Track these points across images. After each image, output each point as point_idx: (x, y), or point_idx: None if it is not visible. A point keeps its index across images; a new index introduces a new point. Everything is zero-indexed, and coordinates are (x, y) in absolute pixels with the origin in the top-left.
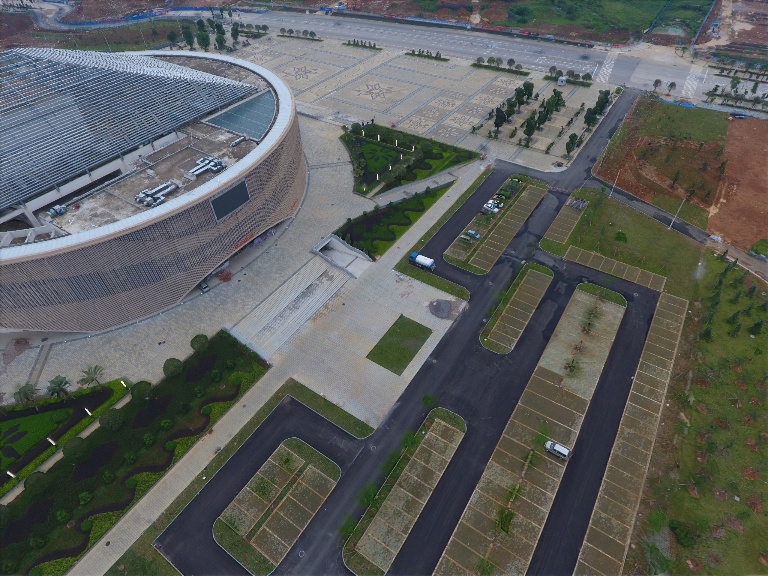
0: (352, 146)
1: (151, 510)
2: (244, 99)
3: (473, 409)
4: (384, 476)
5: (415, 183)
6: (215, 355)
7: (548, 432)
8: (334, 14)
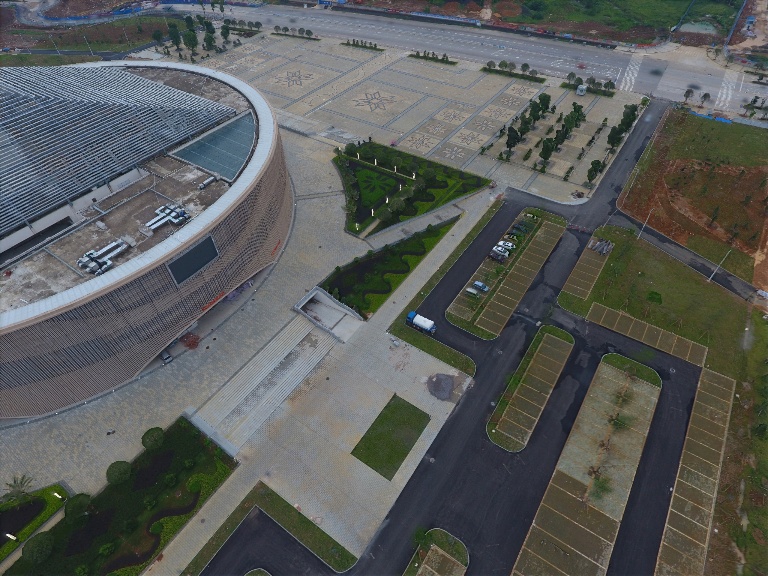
0: (345, 174)
1: None
2: (220, 124)
3: (477, 531)
4: None
5: (415, 219)
6: (172, 451)
7: (569, 568)
8: (334, 8)
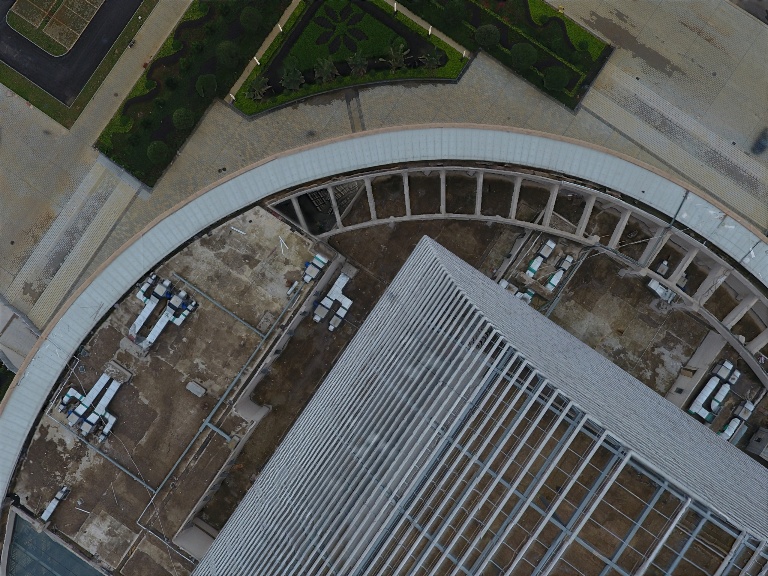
0: None
1: None
2: None
3: None
4: None
5: None
6: None
7: None
8: None
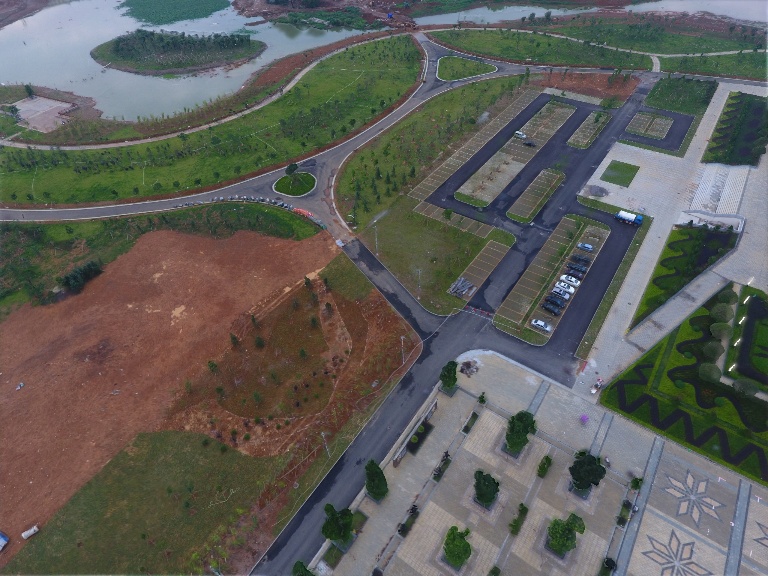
0: None
1: (707, 122)
2: None
3: None
4: (604, 131)
5: None
6: None
7: None
8: None
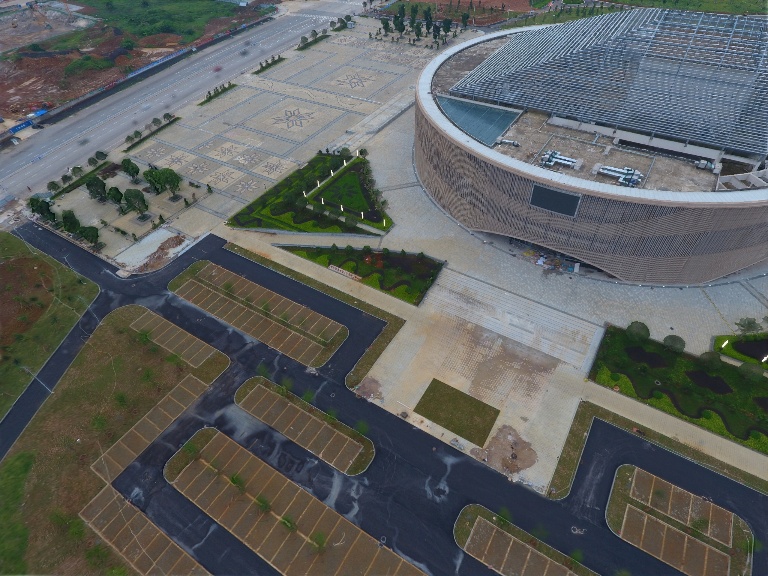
0: None
1: None
2: None
3: None
4: None
5: None
6: None
7: None
8: (49, 122)
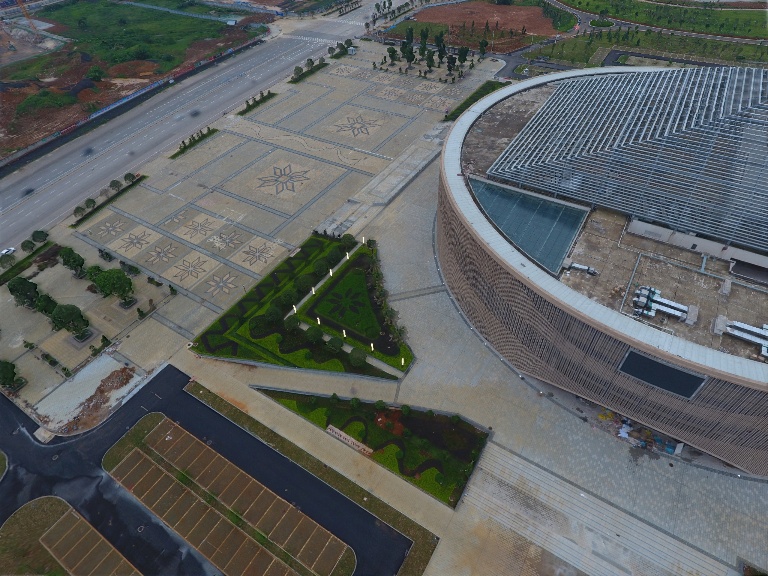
0: None
1: None
2: None
3: None
4: None
5: None
6: None
7: None
8: None
